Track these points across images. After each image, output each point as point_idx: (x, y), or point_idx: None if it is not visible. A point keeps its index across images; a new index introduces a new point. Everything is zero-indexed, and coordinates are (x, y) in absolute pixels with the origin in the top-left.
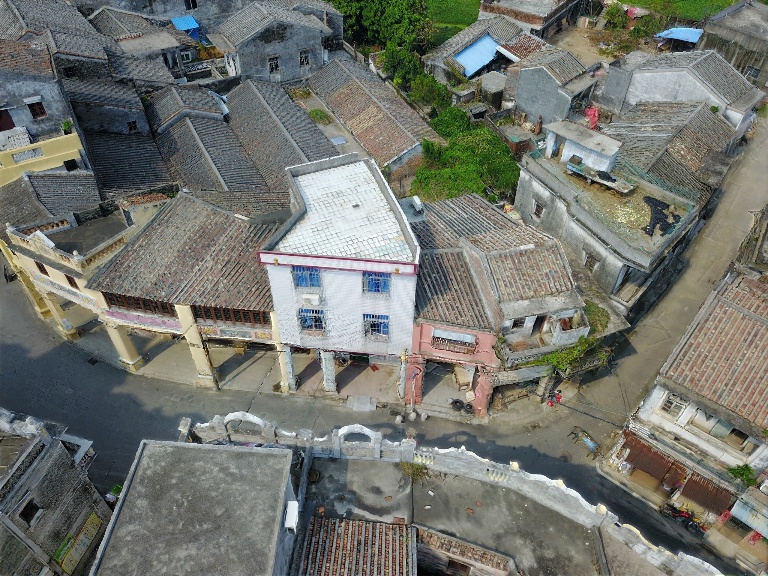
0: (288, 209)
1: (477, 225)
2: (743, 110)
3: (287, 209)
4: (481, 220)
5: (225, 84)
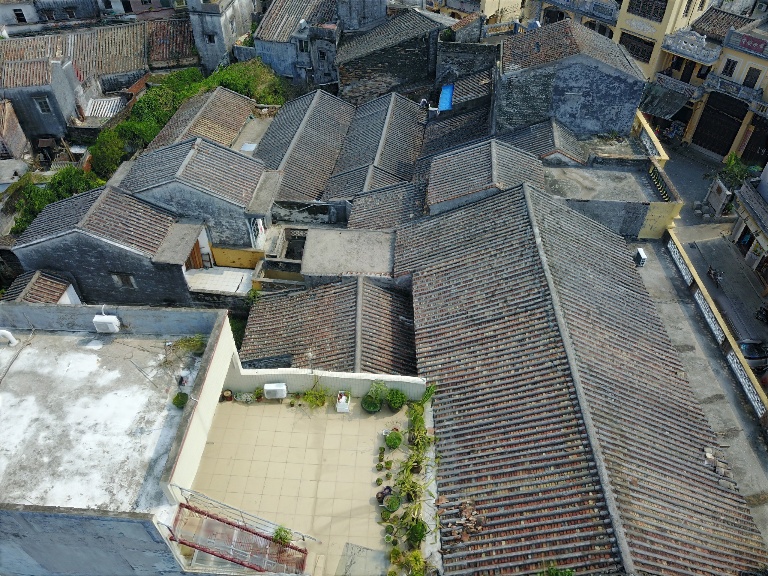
0: (389, 6)
1: (294, 2)
2: (2, 26)
3: (390, 6)
4: (286, 7)
5: (293, 207)
